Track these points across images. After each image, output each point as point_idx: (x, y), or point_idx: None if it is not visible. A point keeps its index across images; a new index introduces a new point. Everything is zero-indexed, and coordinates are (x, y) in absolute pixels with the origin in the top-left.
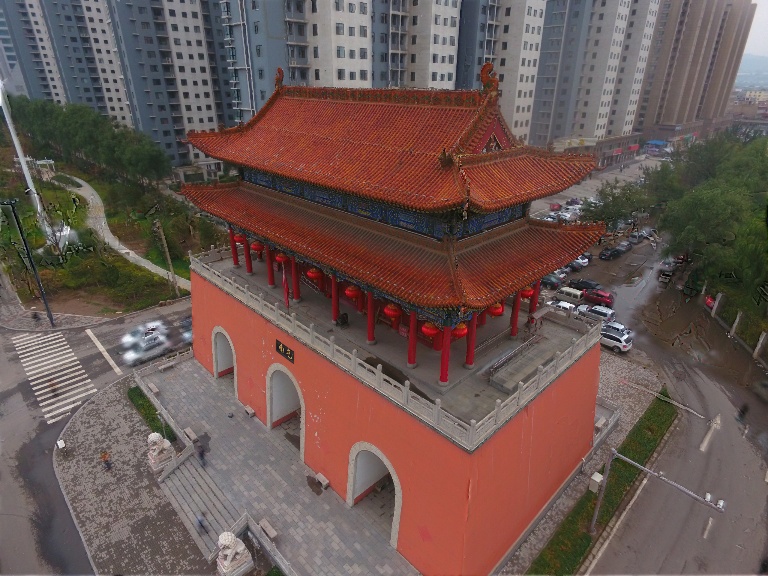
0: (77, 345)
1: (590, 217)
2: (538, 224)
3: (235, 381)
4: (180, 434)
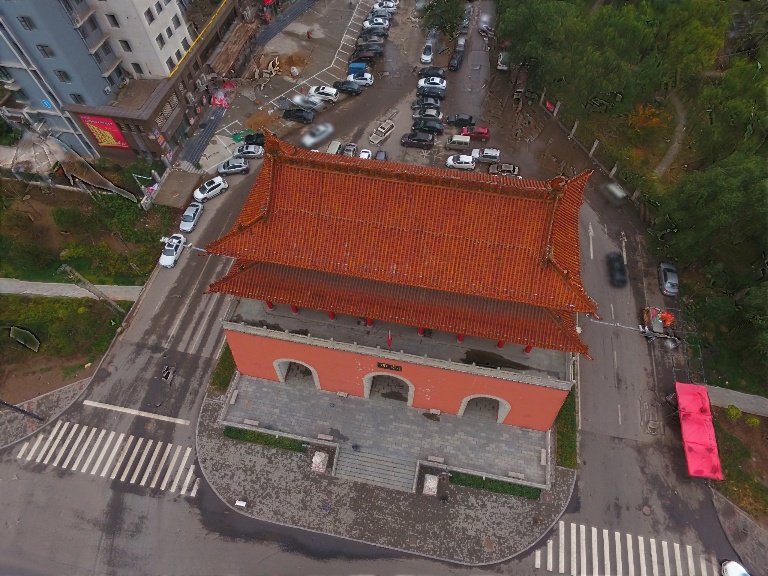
0: (103, 423)
1: (431, 25)
2: None
3: (316, 382)
4: (317, 441)
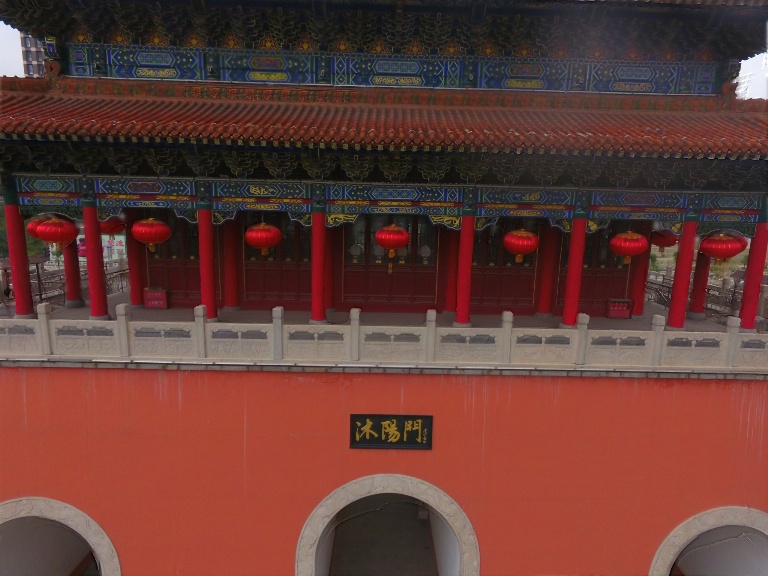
0: None
1: None
2: (22, 88)
3: None
4: None
